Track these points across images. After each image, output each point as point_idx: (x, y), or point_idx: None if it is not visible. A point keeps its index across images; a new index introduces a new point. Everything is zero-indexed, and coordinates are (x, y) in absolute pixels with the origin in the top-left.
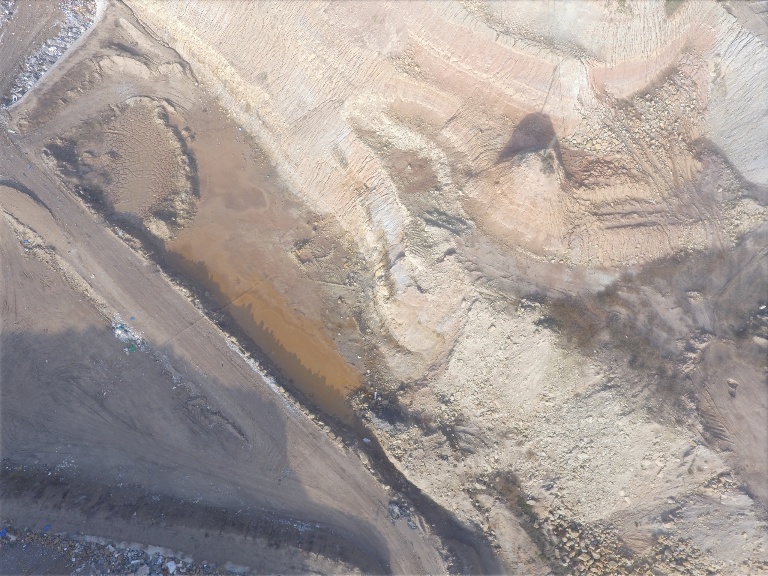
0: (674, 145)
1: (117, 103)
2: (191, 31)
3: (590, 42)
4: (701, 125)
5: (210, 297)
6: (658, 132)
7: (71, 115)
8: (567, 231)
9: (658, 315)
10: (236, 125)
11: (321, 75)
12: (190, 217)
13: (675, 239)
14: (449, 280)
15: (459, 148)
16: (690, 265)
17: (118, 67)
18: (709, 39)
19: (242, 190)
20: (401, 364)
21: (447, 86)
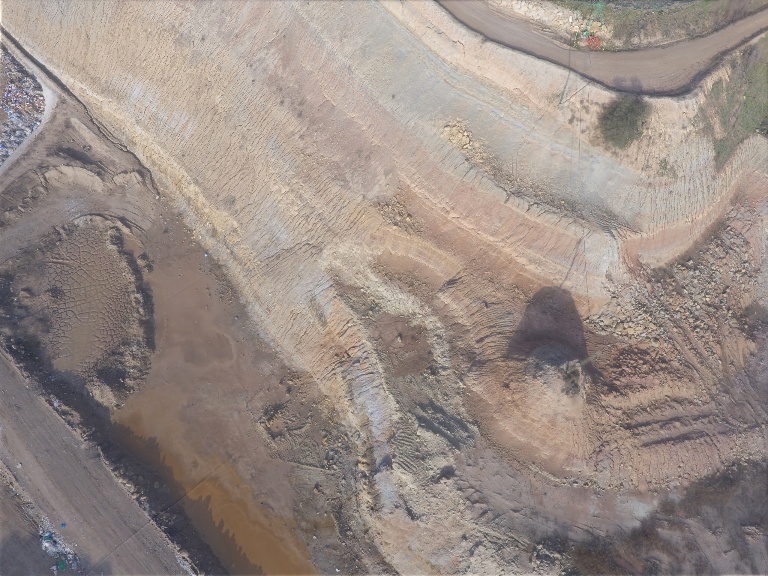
0: (723, 323)
1: (64, 224)
2: (151, 138)
3: (622, 208)
4: (753, 290)
5: (160, 489)
6: (704, 310)
7: (8, 242)
8: (593, 449)
9: (708, 563)
10: (201, 250)
11: (296, 212)
12: (142, 376)
13: (726, 451)
14: (446, 510)
15: (459, 319)
16: (745, 484)
17: (67, 178)
18: (765, 189)
19: (205, 337)
20: None
21: (445, 243)
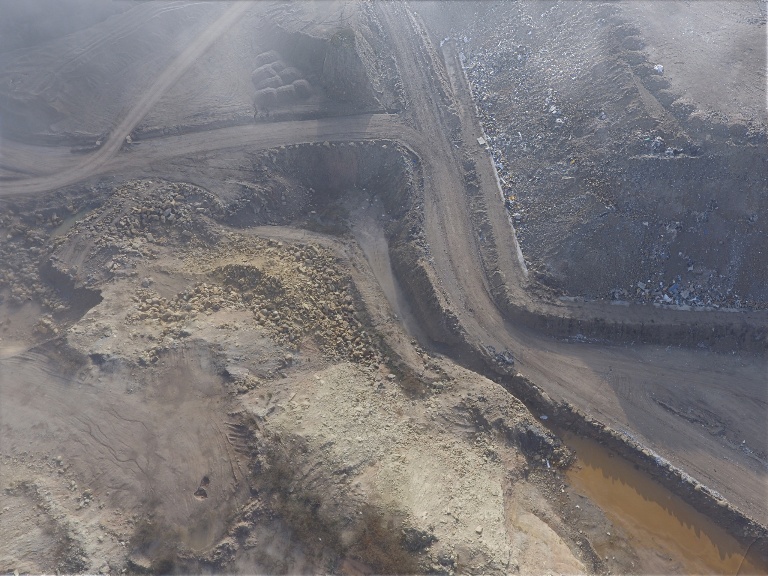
0: None
1: None
2: None
3: None
4: None
5: None
6: None
7: None
8: None
9: None
10: None
11: None
12: None
13: None
14: None
15: None
16: None
17: None
18: None
19: None
20: (537, 500)
21: None
